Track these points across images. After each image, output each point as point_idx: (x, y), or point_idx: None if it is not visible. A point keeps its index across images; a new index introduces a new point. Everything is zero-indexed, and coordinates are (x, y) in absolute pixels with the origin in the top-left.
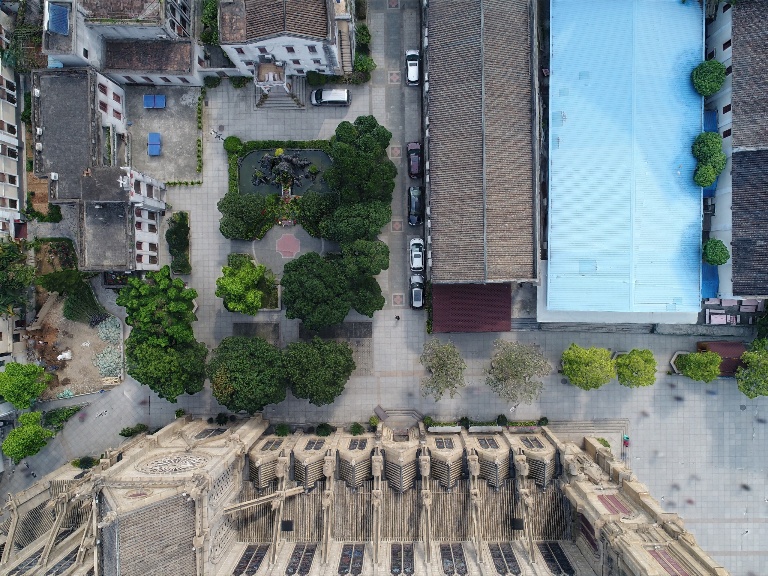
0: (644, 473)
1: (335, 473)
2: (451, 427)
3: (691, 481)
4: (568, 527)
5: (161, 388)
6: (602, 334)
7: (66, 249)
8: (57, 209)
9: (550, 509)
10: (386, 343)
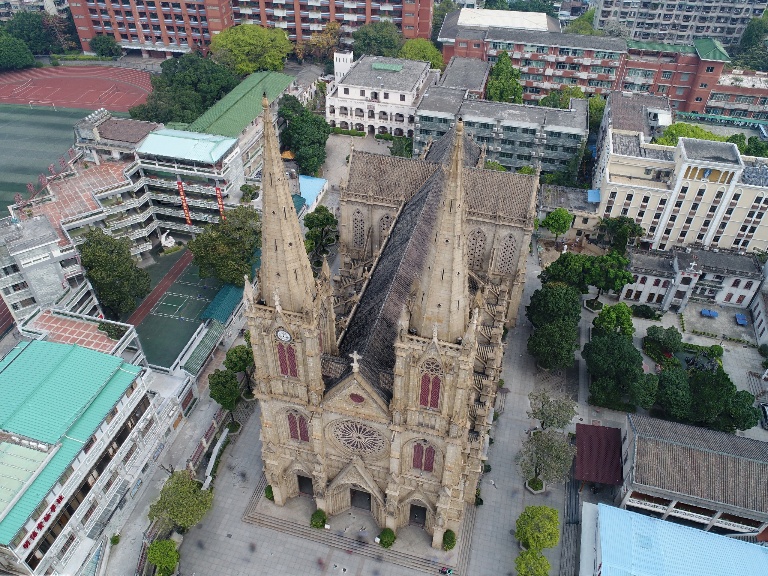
0: None
1: None
2: None
3: None
4: None
5: None
6: None
7: None
8: None
9: None
10: None
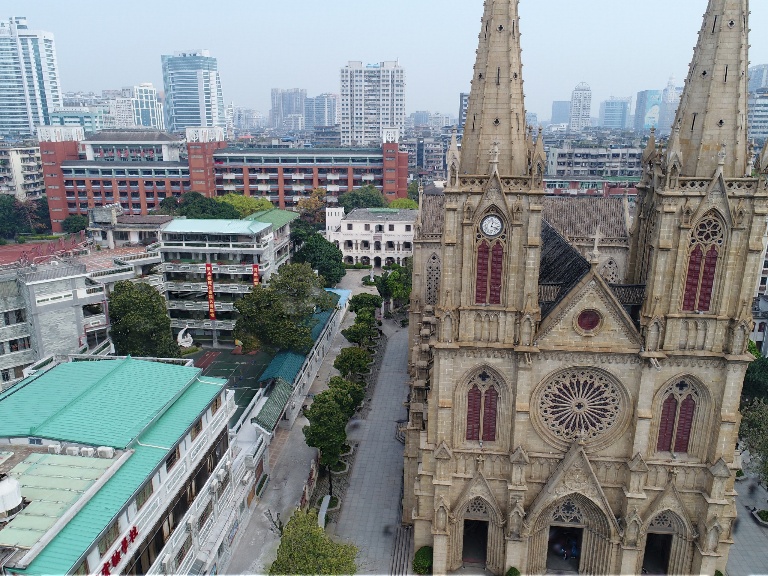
0: None
1: None
2: None
3: None
4: None
5: None
6: None
7: None
8: None
9: None
10: None
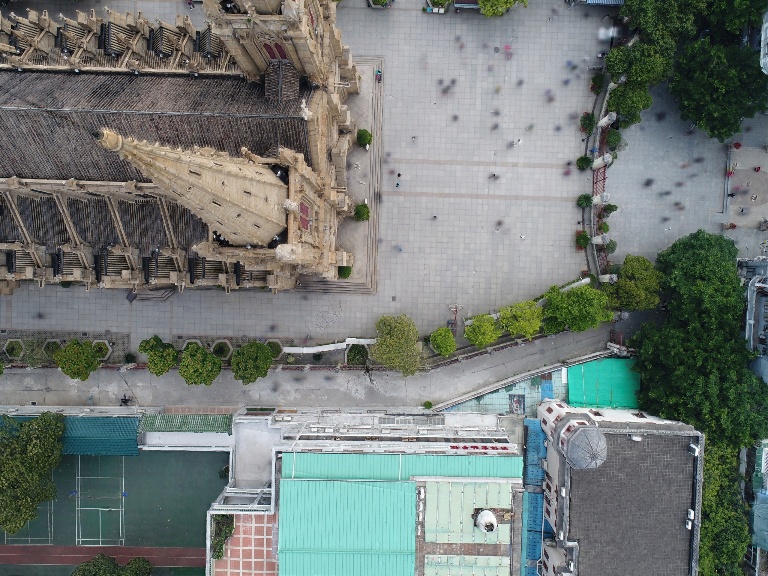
0: (396, 112)
1: (56, 47)
2: None
3: (442, 122)
4: None
5: None
6: None
7: None
8: None
9: None
10: None
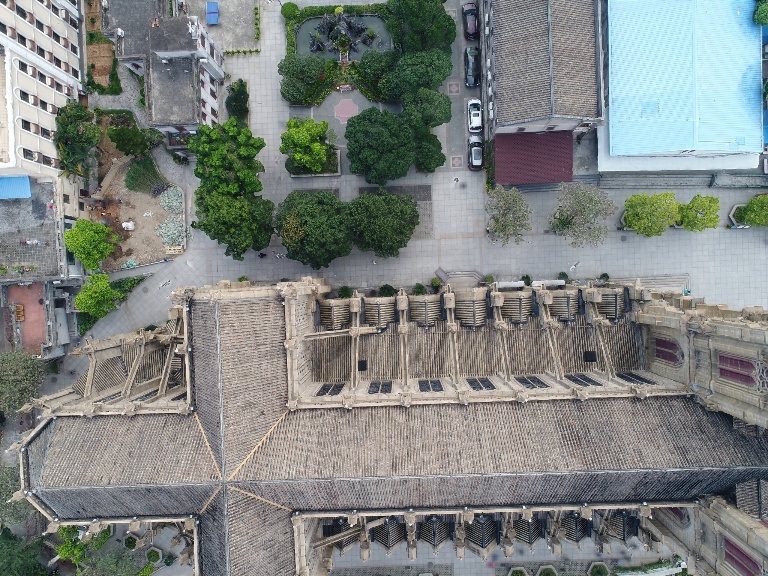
0: None
1: None
2: (514, 282)
3: None
4: (641, 358)
5: (231, 238)
6: (660, 190)
7: (127, 120)
8: (117, 81)
9: (622, 341)
10: (445, 205)
